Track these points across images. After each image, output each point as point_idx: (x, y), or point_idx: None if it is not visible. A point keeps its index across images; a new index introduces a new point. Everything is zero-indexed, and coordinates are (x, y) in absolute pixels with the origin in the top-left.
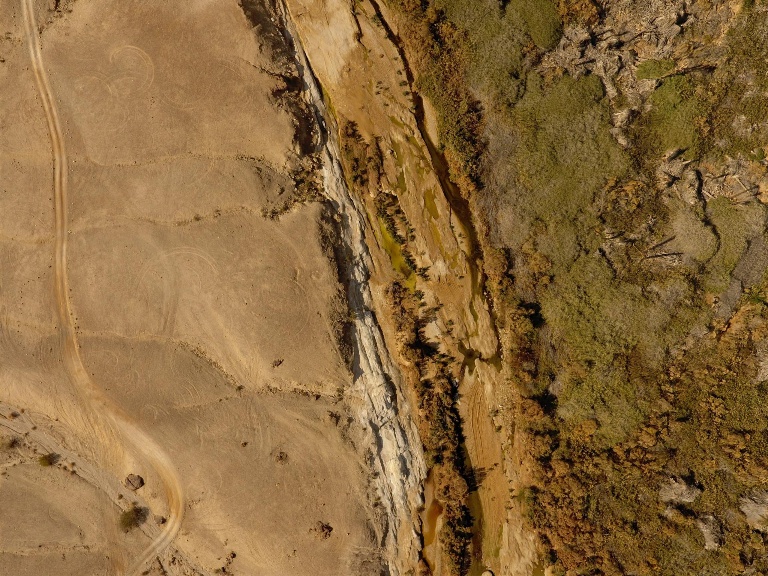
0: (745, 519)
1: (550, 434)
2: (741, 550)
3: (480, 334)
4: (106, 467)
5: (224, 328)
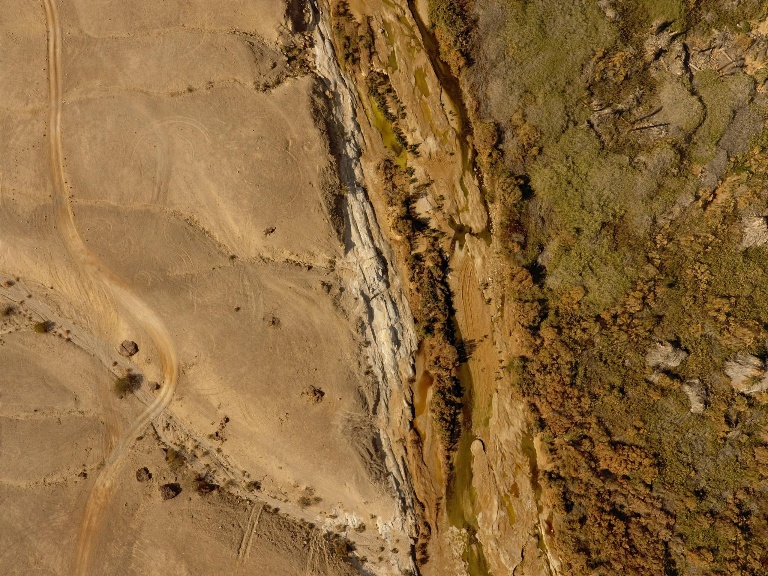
0: (730, 382)
1: (539, 302)
2: (726, 413)
3: (470, 209)
4: (101, 335)
5: (217, 196)
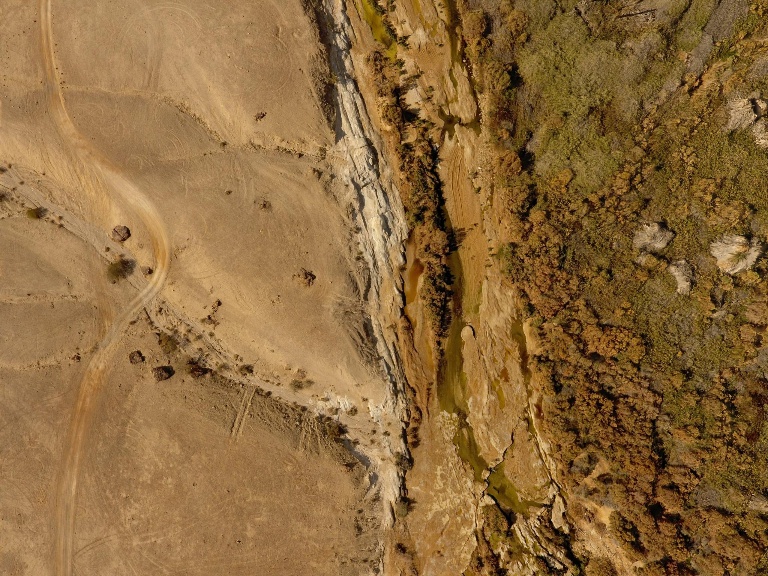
0: (716, 261)
1: None
2: (712, 293)
3: (460, 100)
4: (93, 221)
5: (208, 82)
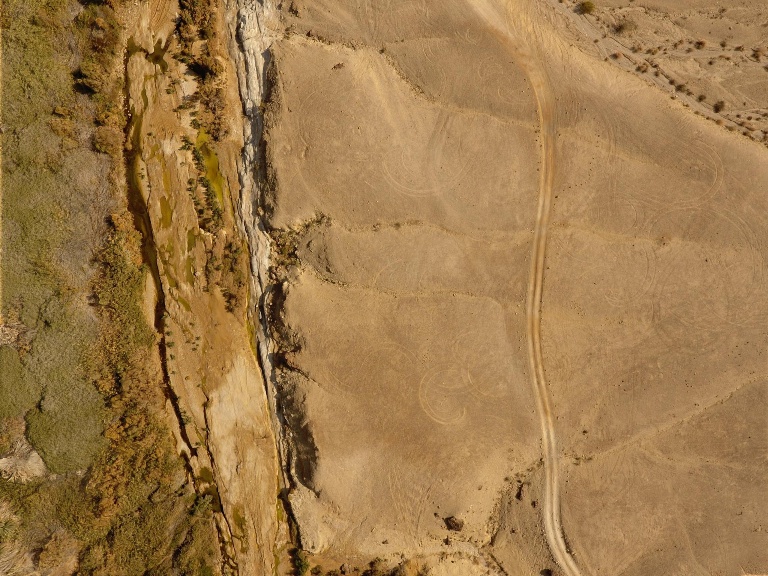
0: None
1: None
2: None
3: (143, 76)
4: None
5: (386, 109)
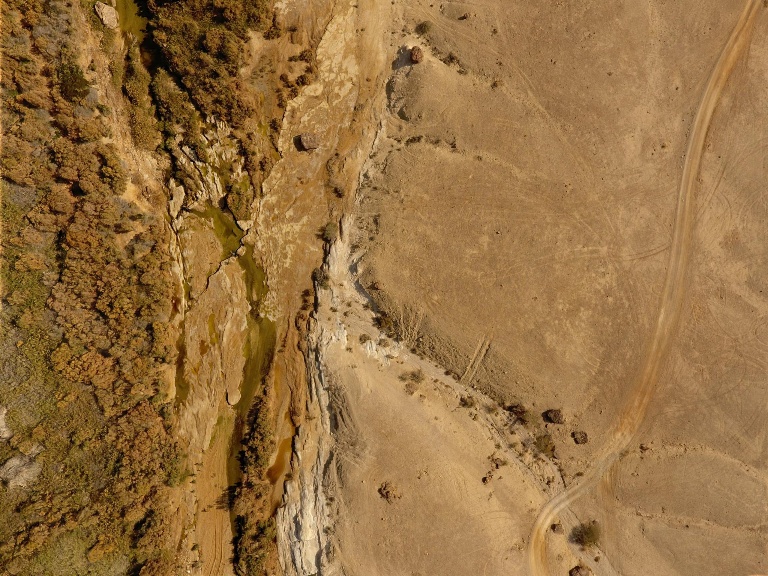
0: None
1: None
2: None
3: None
4: None
5: None
